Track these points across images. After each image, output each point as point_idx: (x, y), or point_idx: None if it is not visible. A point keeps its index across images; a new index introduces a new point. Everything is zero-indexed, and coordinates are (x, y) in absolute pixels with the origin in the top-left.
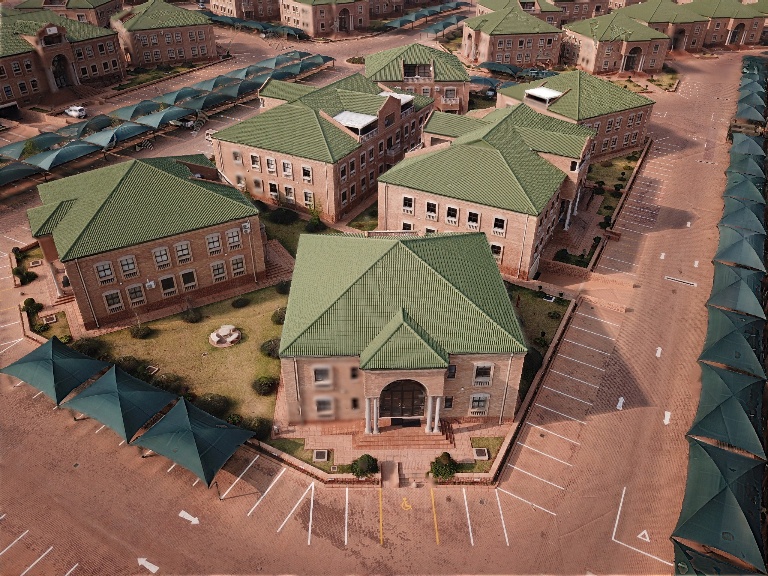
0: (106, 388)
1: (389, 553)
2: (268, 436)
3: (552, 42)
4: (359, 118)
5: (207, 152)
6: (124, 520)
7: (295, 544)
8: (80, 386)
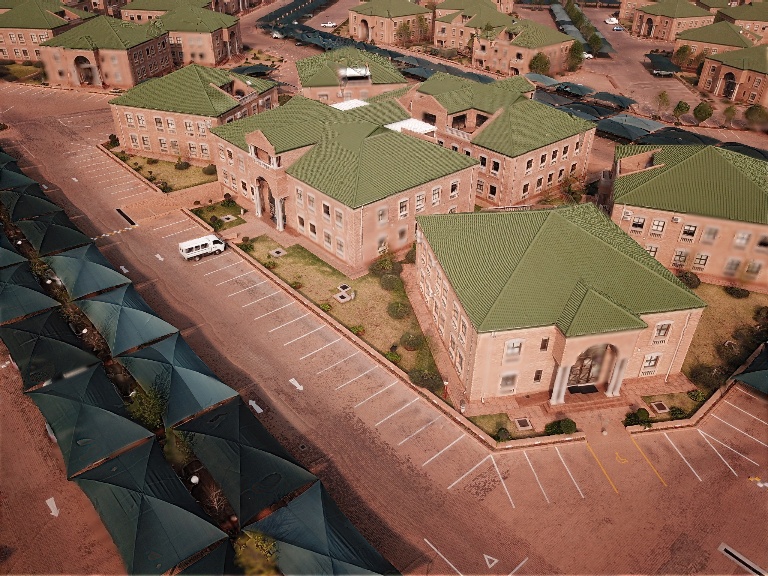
0: None
1: None
2: None
3: (165, 44)
4: (411, 124)
5: (226, 266)
6: None
7: None
8: None
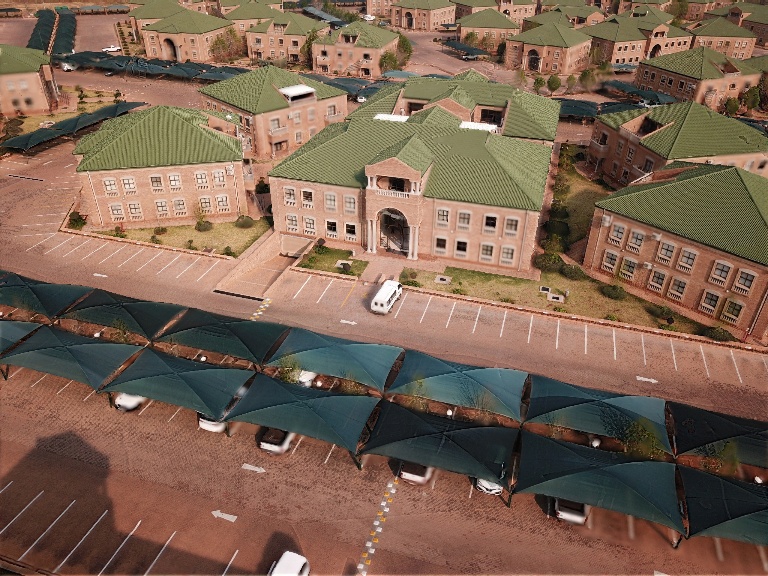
0: None
1: None
2: None
3: None
4: (473, 127)
5: (426, 307)
6: None
7: None
8: None
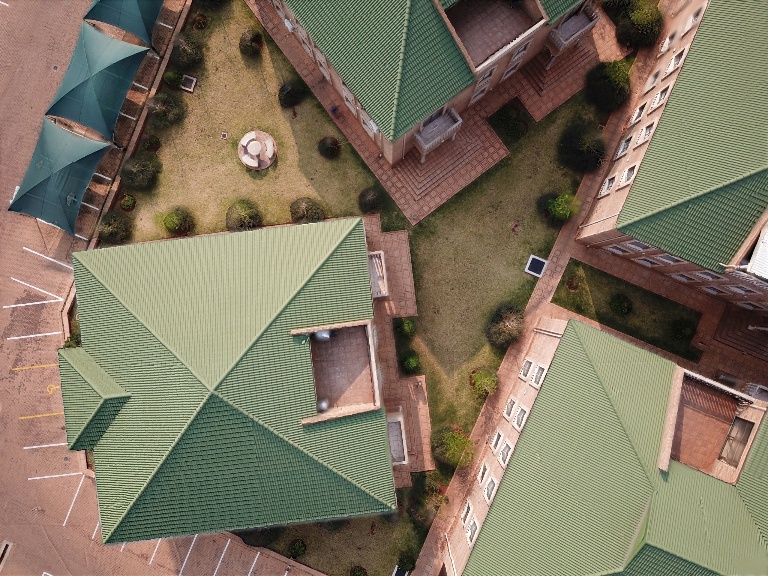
0: (99, 60)
1: (5, 377)
2: (111, 243)
3: None
4: None
5: None
6: (6, 140)
7: (2, 295)
8: (114, 27)
